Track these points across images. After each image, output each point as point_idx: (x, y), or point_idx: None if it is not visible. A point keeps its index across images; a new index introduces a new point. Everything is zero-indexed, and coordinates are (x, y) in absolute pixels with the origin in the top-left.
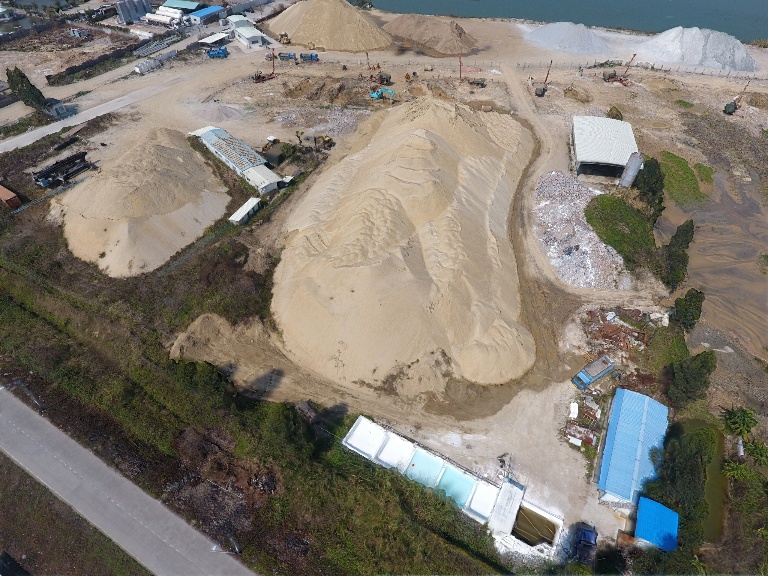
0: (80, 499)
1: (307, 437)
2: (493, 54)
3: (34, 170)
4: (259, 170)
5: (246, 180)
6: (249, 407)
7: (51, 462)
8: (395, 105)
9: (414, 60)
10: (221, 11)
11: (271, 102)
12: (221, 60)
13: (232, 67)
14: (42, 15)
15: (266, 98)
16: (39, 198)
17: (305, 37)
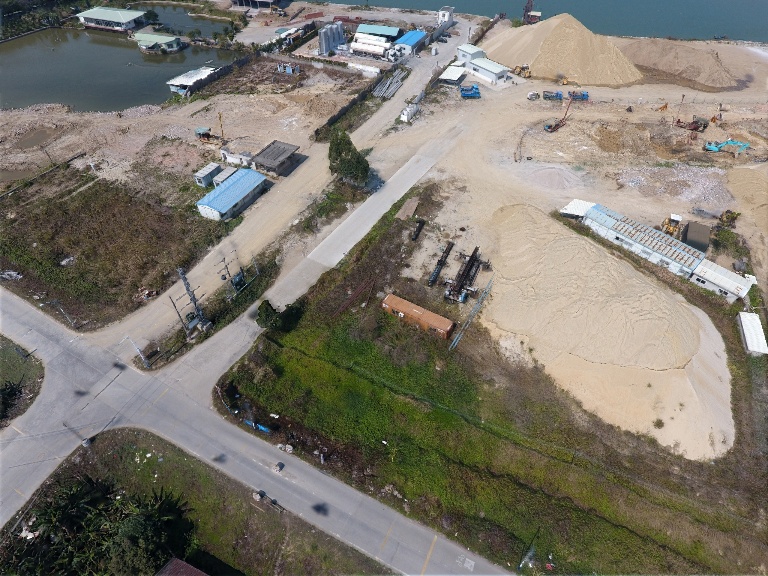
0: None
1: None
2: (766, 86)
3: (413, 272)
4: (713, 268)
5: (692, 280)
6: None
7: None
8: (740, 160)
9: (691, 96)
10: (425, 37)
11: (594, 159)
12: (478, 101)
13: (500, 110)
14: (210, 43)
15: (585, 154)
16: (460, 319)
17: (548, 69)
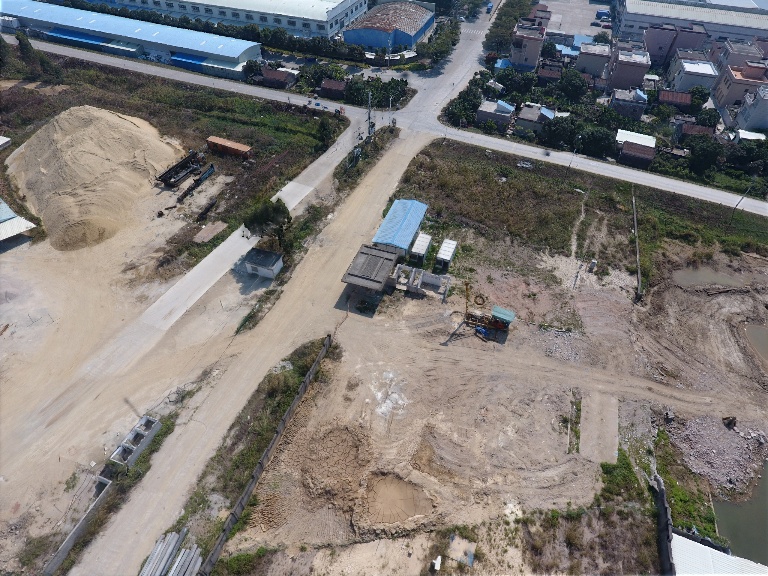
0: (101, 56)
1: (0, 66)
2: None
3: (224, 179)
4: None
5: None
6: (28, 76)
7: (117, 61)
8: None
9: None
10: None
11: None
12: None
13: None
14: None
15: None
16: None
17: None
